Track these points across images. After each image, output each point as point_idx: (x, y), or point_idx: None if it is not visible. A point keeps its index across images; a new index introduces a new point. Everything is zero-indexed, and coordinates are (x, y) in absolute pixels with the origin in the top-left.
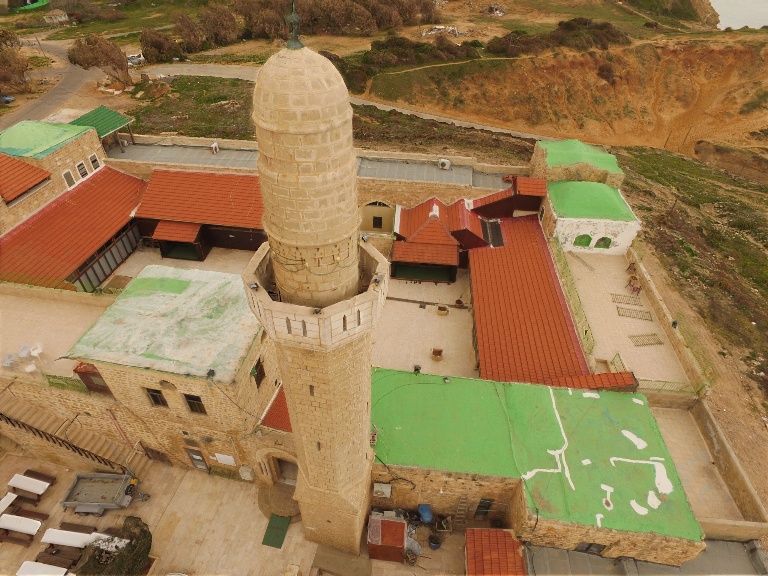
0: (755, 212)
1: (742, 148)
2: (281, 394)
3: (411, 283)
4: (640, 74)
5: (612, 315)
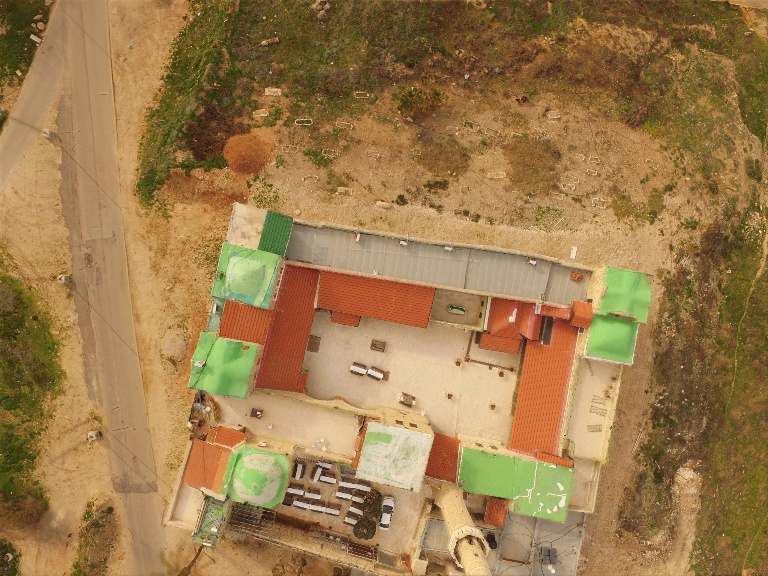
0: None
1: None
2: None
3: None
4: None
5: (586, 411)
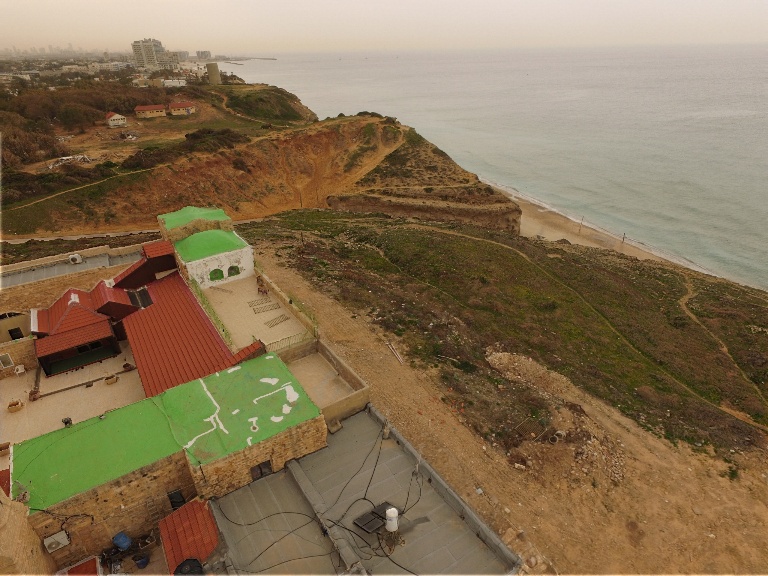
0: (368, 229)
1: (355, 194)
2: None
3: (72, 372)
4: (267, 161)
5: (250, 315)
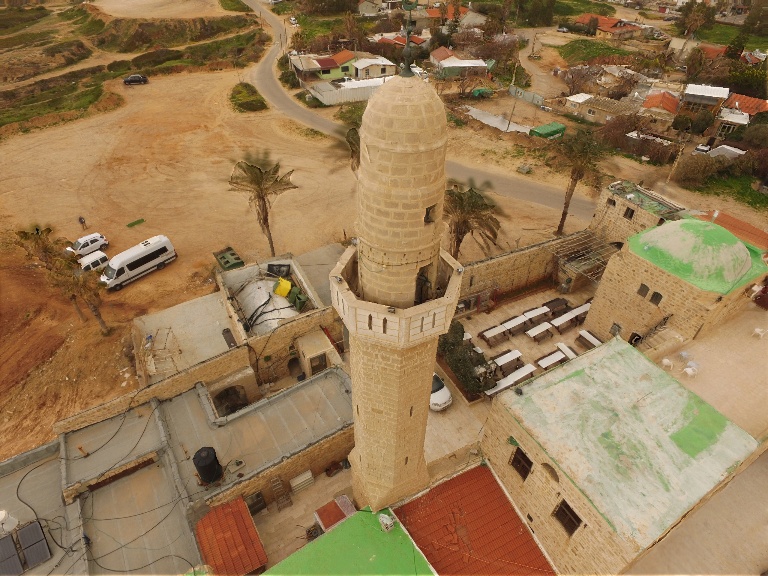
0: None
1: None
2: (518, 522)
3: None
4: None
5: None
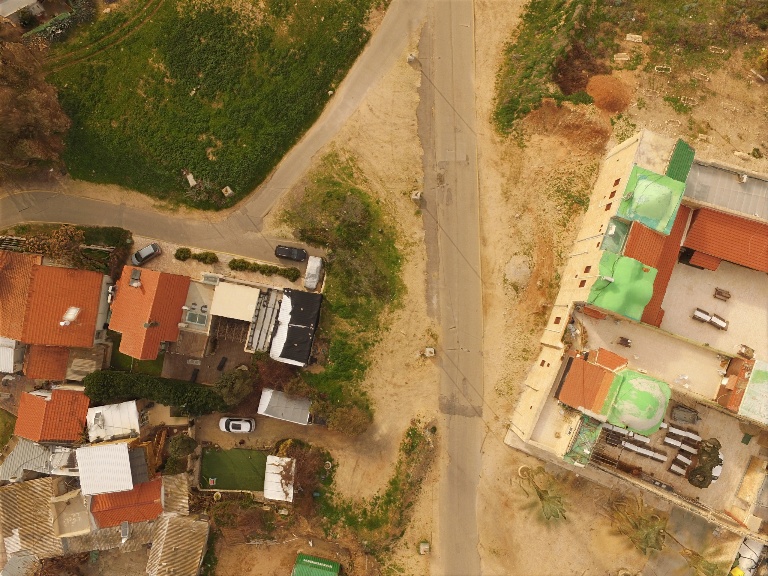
0: None
1: None
2: None
3: None
4: None
5: None
